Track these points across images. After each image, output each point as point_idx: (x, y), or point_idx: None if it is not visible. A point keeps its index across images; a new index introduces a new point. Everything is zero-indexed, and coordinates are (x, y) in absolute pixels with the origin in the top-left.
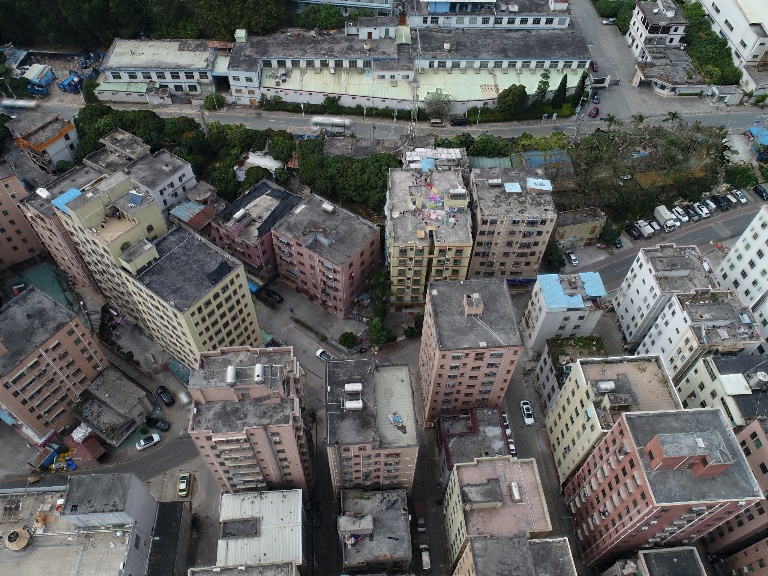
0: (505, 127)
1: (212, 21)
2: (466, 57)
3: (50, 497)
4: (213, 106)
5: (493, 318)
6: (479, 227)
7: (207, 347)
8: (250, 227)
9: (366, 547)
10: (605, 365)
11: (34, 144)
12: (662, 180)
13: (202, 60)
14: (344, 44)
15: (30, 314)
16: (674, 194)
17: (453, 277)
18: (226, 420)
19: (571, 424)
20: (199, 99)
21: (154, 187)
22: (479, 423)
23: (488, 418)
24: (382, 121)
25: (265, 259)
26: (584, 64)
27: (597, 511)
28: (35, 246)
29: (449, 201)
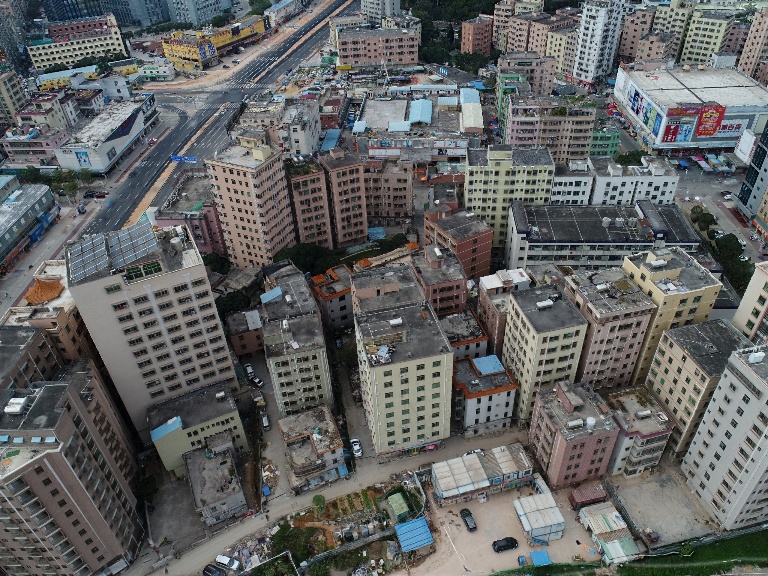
0: None
1: None
2: None
3: None
4: None
5: None
6: None
7: None
8: None
9: None
10: None
11: None
12: None
13: None
14: None
15: None
16: None
17: None
18: None
19: None
20: None
21: None
22: None
23: None
24: None
25: None
26: None
27: None
28: None
29: None
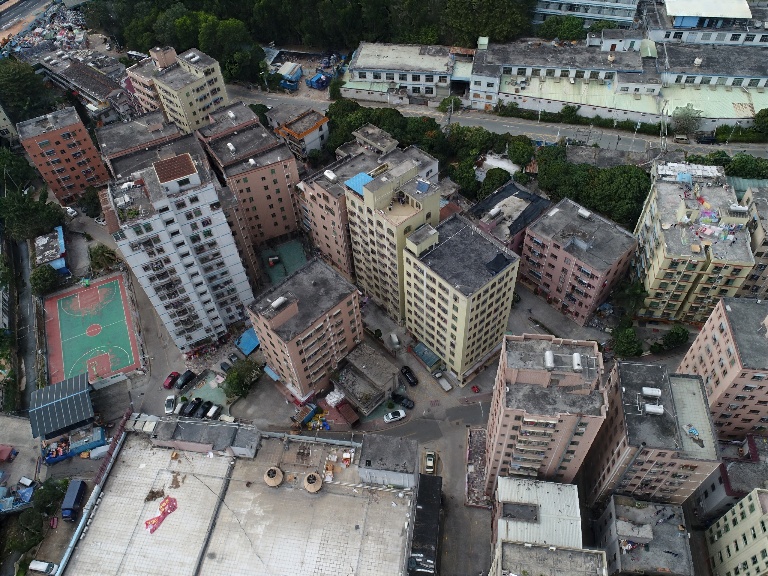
0: (758, 148)
1: (456, 28)
2: (719, 73)
3: (335, 450)
4: None
5: None
6: (758, 248)
7: (470, 334)
8: (501, 225)
9: (642, 556)
10: None
11: (294, 132)
12: None
13: (442, 65)
14: (586, 55)
15: (315, 282)
16: None
17: (718, 297)
18: (536, 403)
19: None
20: (436, 101)
21: None
22: (759, 452)
23: None
24: (621, 133)
25: None
26: None
27: None
28: (291, 224)
29: (727, 218)
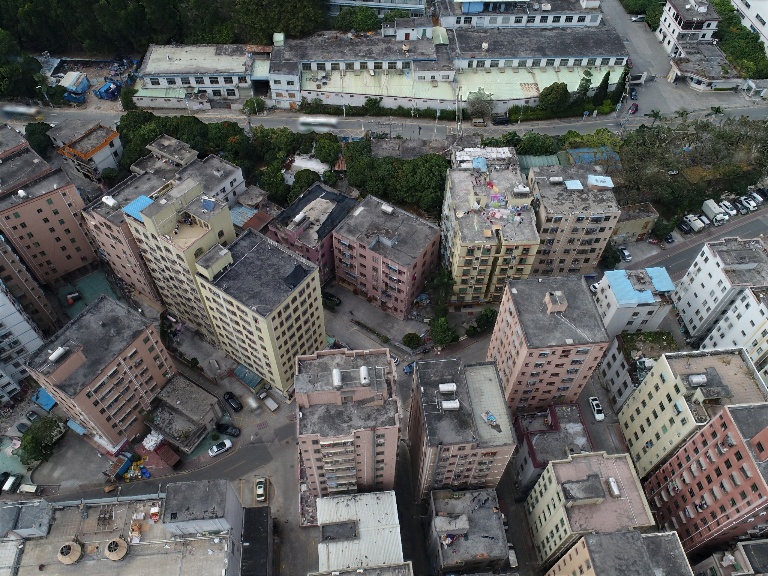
0: (547, 125)
1: (249, 25)
2: (505, 56)
3: (142, 506)
4: (253, 110)
5: (576, 315)
6: (543, 225)
7: (282, 351)
8: (309, 230)
9: (462, 547)
10: (689, 359)
11: (80, 152)
12: (709, 174)
13: (240, 64)
14: (382, 46)
15: (105, 322)
16: (720, 188)
17: (517, 275)
18: (331, 423)
19: (654, 419)
20: (239, 103)
21: (207, 192)
22: (559, 420)
23: (568, 415)
24: (424, 122)
25: (323, 262)
26: (621, 61)
27: (691, 504)
28: (88, 254)
29: (513, 200)
